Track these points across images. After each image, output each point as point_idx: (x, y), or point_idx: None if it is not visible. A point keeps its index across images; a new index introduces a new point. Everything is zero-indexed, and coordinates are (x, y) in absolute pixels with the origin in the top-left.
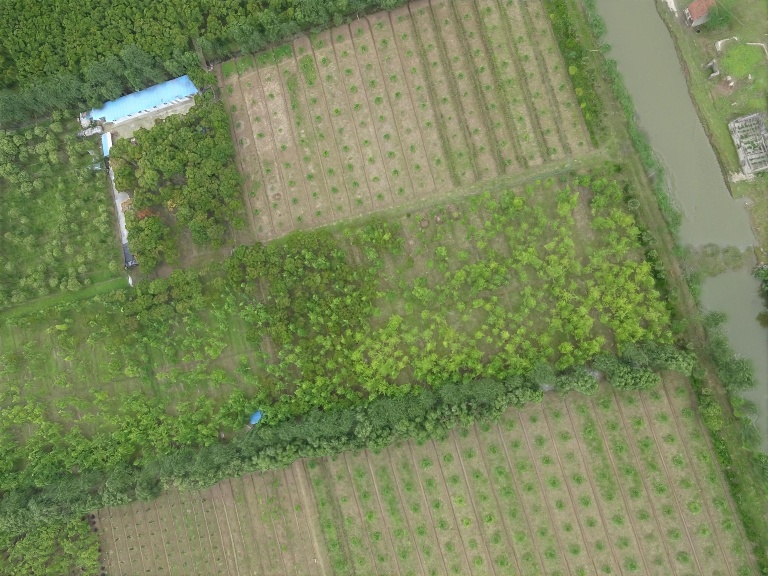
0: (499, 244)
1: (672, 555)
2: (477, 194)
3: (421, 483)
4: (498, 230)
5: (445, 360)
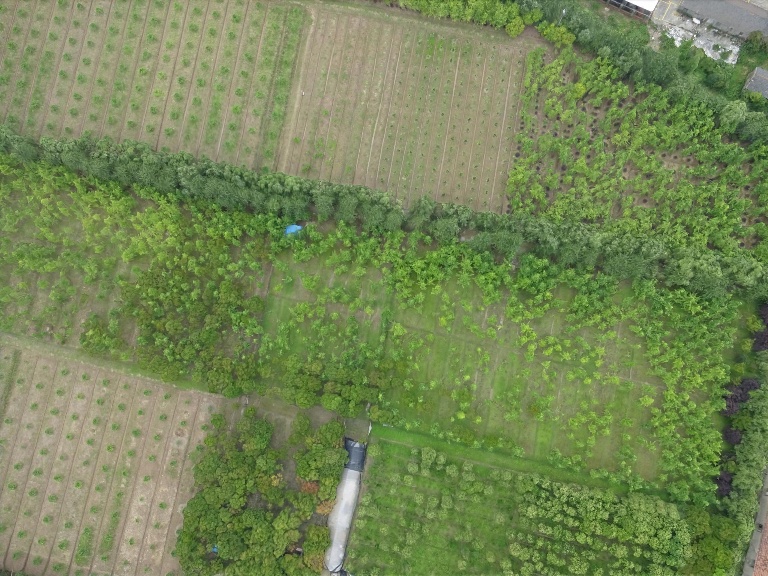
0: (15, 282)
1: (33, 2)
2: (7, 334)
3: (184, 120)
4: (2, 291)
5: (101, 203)
